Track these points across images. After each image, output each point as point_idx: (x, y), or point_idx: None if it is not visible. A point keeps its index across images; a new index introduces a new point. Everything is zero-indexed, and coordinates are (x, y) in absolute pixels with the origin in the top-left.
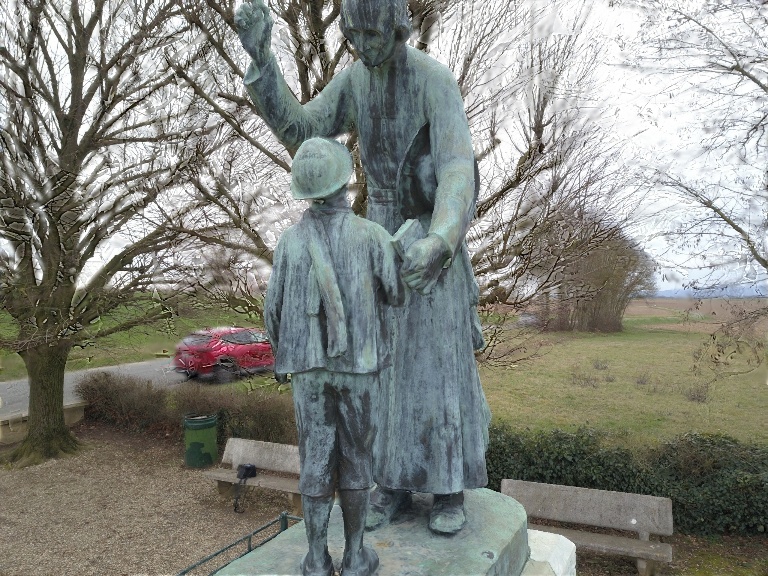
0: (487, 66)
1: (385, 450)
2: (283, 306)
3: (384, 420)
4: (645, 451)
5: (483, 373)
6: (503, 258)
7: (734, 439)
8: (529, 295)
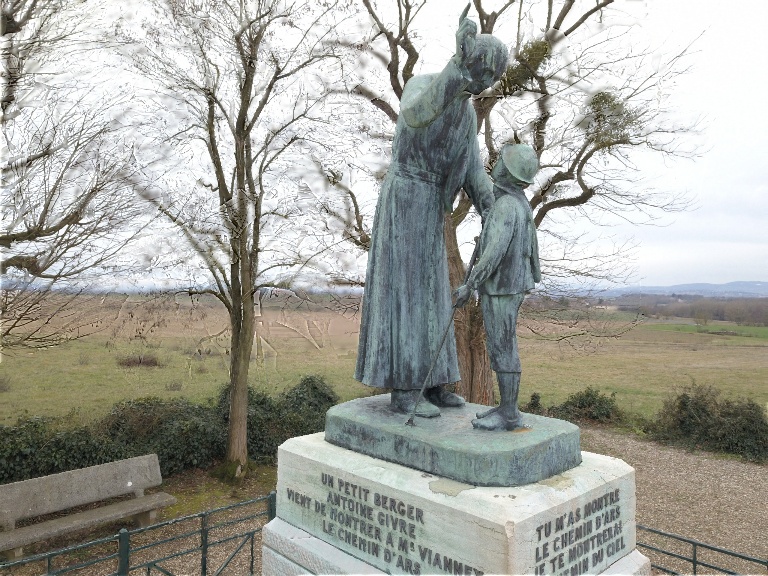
0: (63, 6)
1: (426, 362)
2: (518, 250)
3: (422, 340)
4: (96, 425)
5: None
6: (44, 225)
7: (160, 399)
8: (81, 267)
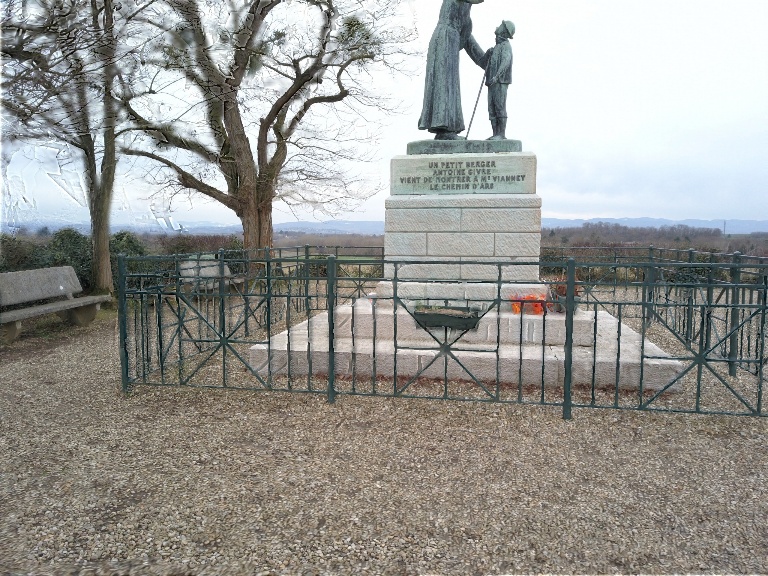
0: None
1: None
2: None
3: None
4: None
5: (11, 143)
6: None
7: None
8: None
